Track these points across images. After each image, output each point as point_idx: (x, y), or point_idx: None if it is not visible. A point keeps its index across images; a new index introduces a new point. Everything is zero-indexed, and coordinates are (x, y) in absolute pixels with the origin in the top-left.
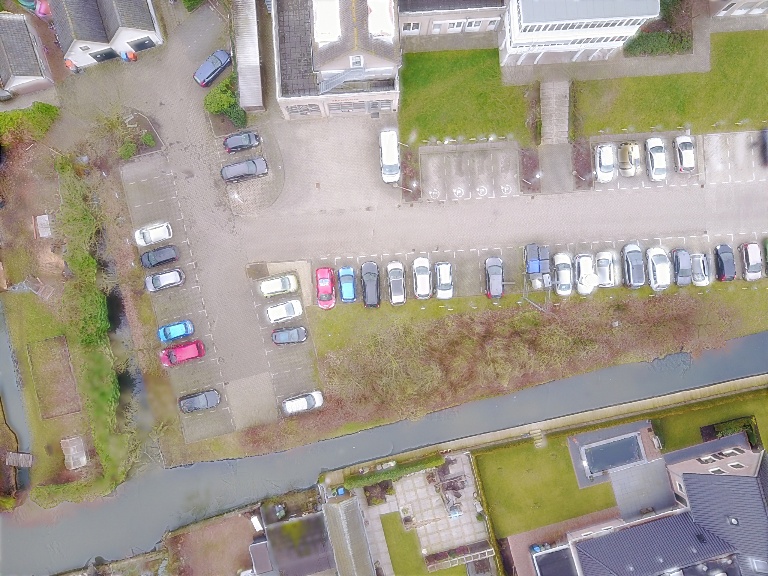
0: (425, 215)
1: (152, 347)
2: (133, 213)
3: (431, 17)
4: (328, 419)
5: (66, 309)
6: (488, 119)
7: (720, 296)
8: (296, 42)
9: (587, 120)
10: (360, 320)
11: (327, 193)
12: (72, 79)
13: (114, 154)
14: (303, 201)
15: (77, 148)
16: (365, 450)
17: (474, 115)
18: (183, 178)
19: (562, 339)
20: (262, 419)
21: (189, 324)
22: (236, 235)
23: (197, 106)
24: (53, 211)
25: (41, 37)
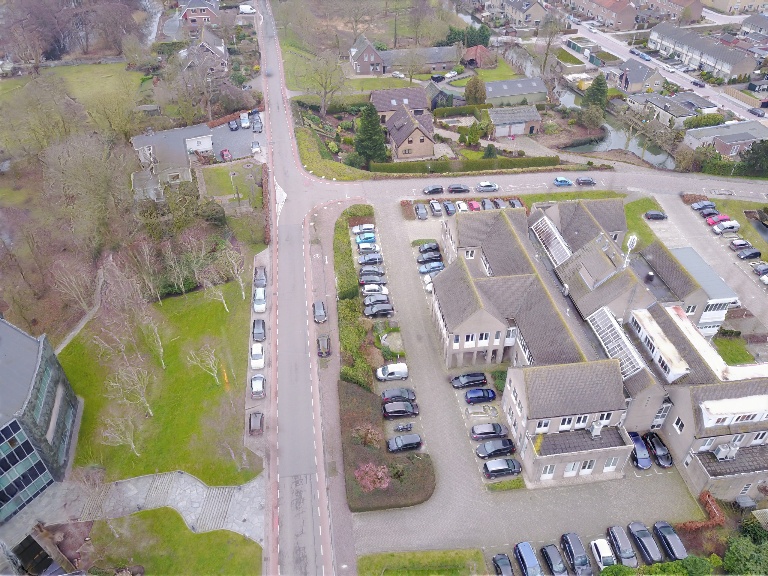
0: None
1: None
2: None
3: None
4: None
5: None
6: (743, 359)
7: (767, 257)
8: None
9: None
10: None
11: None
12: None
13: None
14: None
15: None
16: None
17: None
18: None
19: None
20: None
21: None
22: None
23: None
24: None
25: None
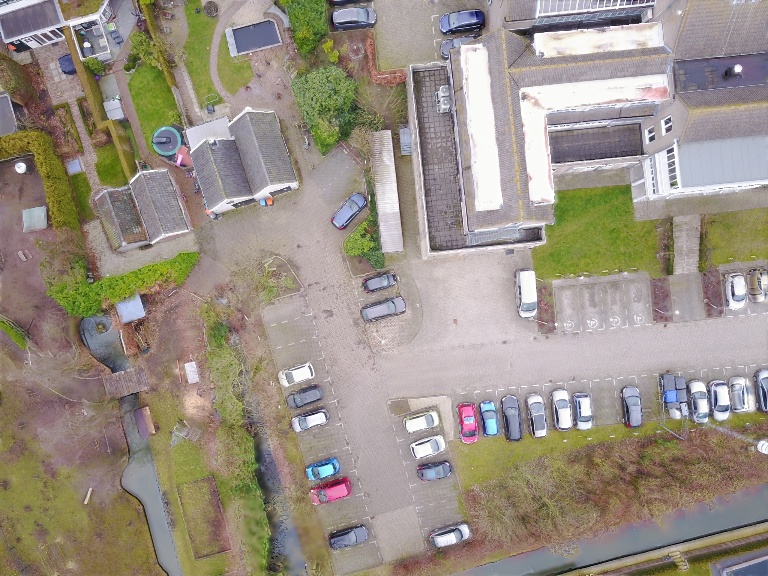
0: (560, 346)
1: (299, 485)
2: (275, 354)
3: (573, 166)
4: (475, 551)
5: (223, 459)
6: (620, 252)
7: None
8: (442, 195)
9: (717, 249)
10: (501, 452)
11: (464, 329)
12: (211, 225)
13: (255, 298)
14: (441, 337)
15: (218, 292)
16: (502, 571)
17: (607, 249)
18: (322, 318)
19: (711, 476)
20: (408, 551)
21: (336, 463)
22: (376, 372)
23: (334, 247)
24: (197, 355)
25: (179, 185)
